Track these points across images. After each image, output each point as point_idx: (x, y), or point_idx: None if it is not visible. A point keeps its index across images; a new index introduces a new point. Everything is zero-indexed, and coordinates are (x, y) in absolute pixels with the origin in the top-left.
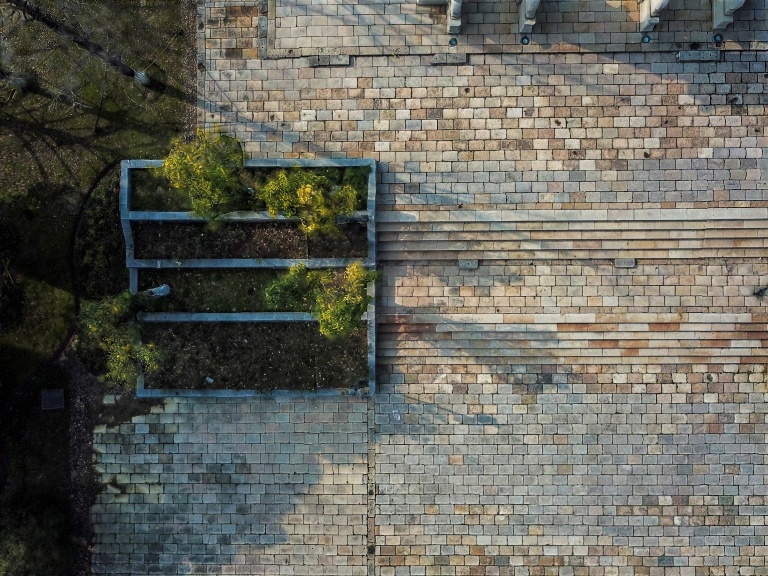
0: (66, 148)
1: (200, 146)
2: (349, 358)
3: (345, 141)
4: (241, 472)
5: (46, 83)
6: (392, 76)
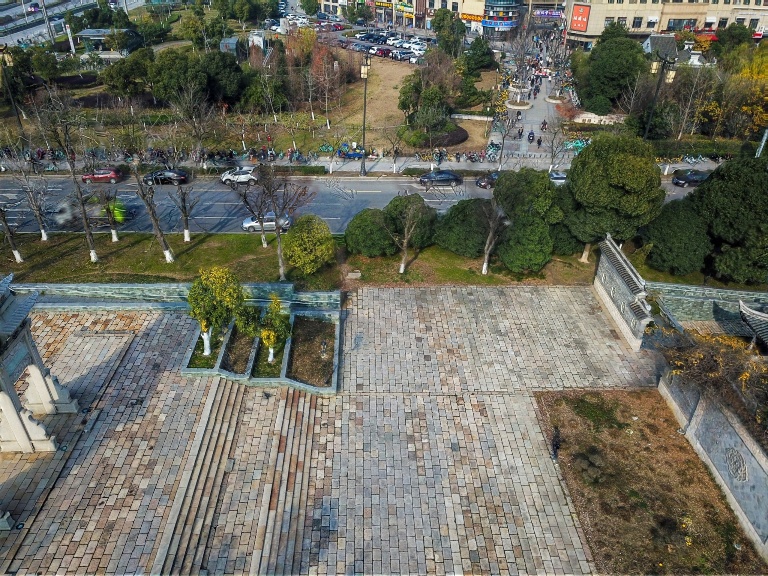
0: None
1: None
2: None
3: None
4: None
5: None
6: None
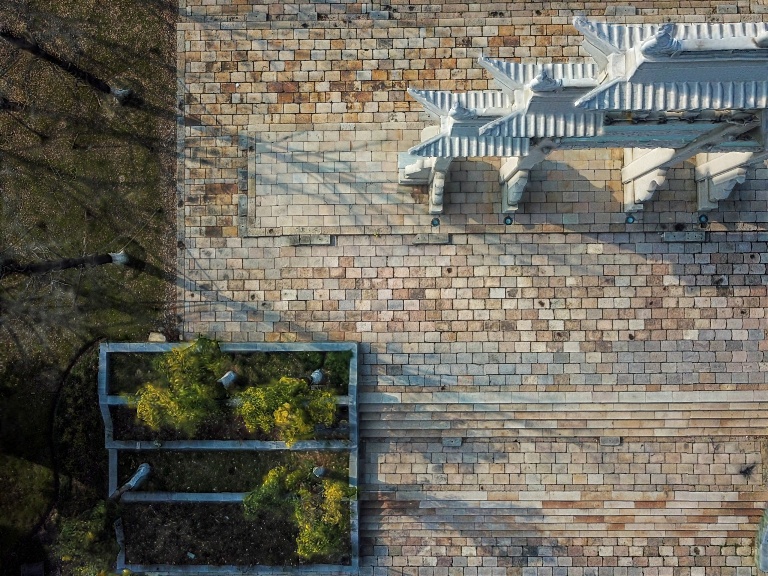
0: (44, 325)
1: (176, 359)
2: None
3: (326, 321)
4: None
5: (24, 260)
6: (374, 255)
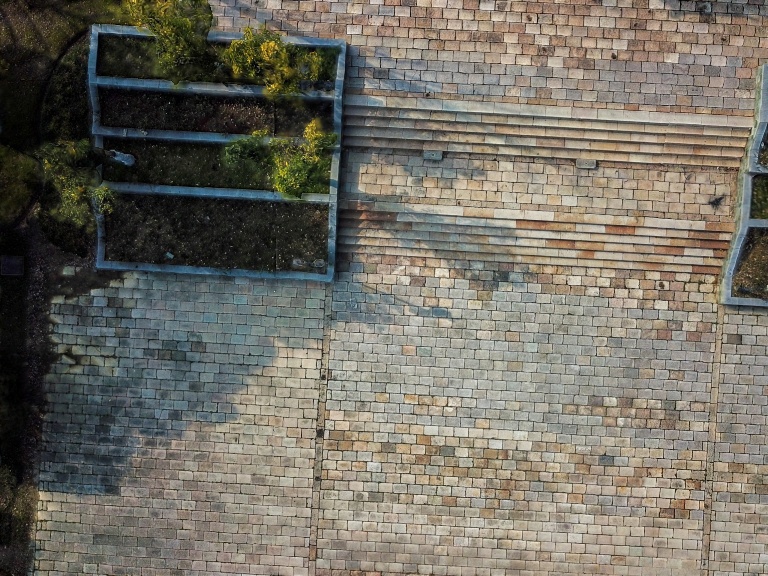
0: (38, 11)
1: None
2: (310, 242)
3: (318, 22)
4: (196, 350)
5: None
6: None
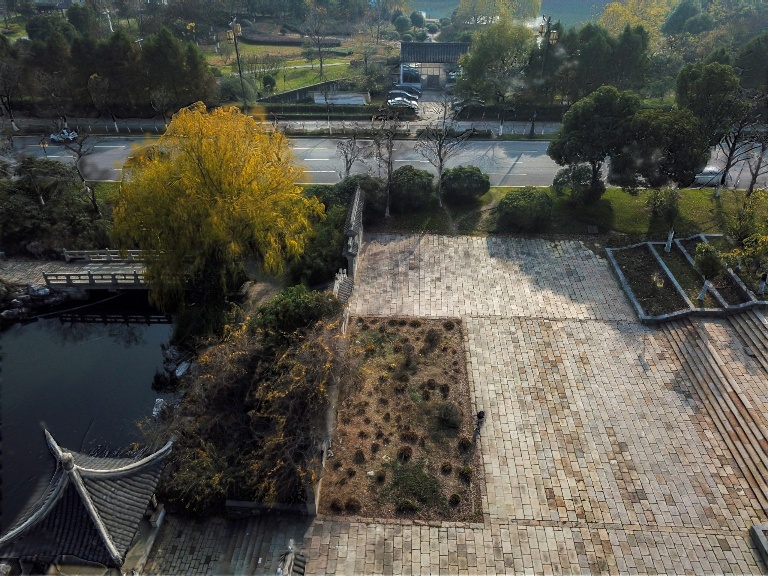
0: (719, 228)
1: None
2: (660, 309)
3: None
4: (575, 279)
5: None
6: None
